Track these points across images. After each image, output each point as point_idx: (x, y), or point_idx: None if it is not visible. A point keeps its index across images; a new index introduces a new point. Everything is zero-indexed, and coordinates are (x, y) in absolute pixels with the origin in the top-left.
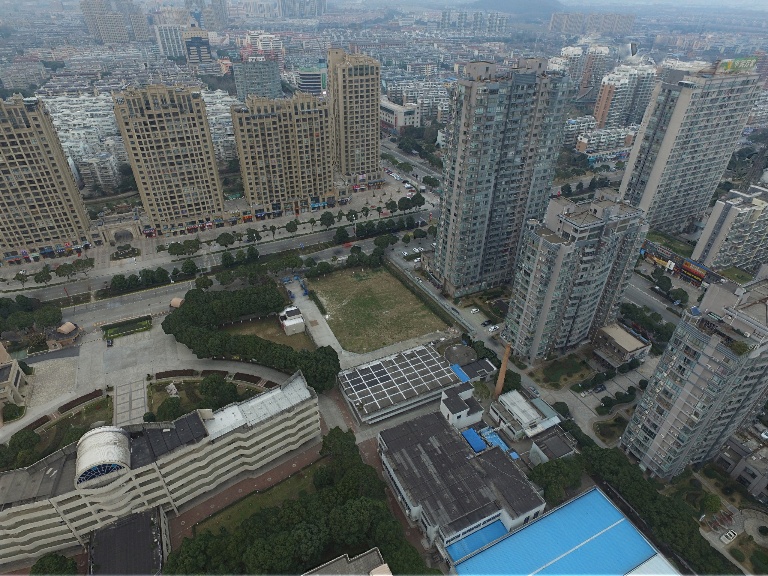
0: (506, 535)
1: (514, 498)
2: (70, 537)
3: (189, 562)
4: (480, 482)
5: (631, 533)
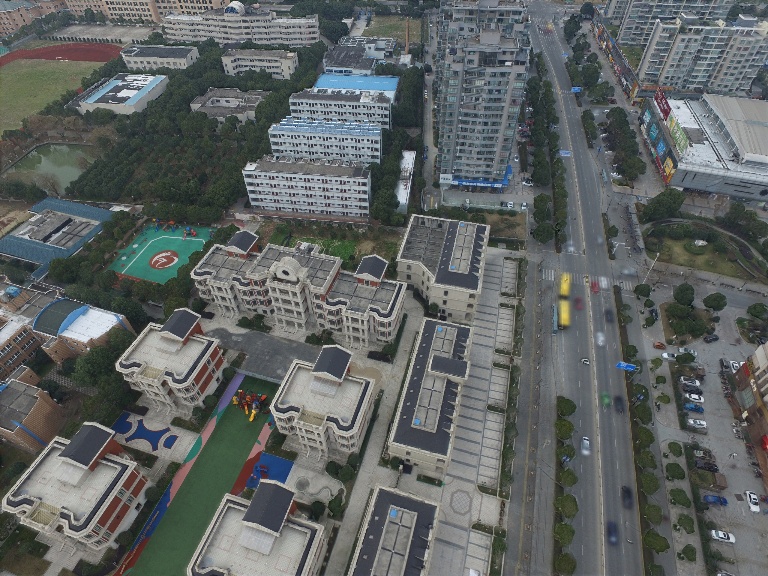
0: (348, 74)
1: (361, 67)
2: (221, 42)
3: (245, 43)
4: (355, 62)
5: (394, 86)
